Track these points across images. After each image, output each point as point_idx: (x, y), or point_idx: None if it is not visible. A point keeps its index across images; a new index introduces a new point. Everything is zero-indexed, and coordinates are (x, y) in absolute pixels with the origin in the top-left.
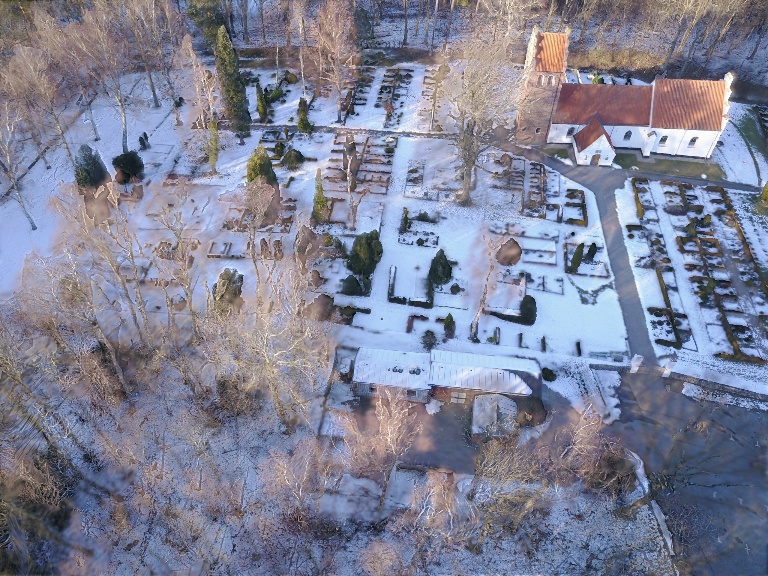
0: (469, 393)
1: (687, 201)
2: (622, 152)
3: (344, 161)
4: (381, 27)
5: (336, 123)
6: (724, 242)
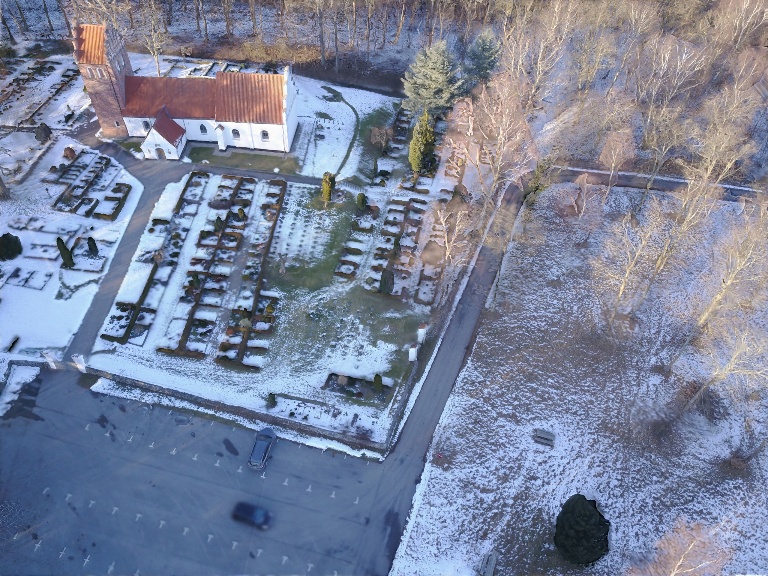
0: None
1: (237, 195)
2: (203, 146)
3: None
4: (83, 19)
5: None
6: (251, 236)
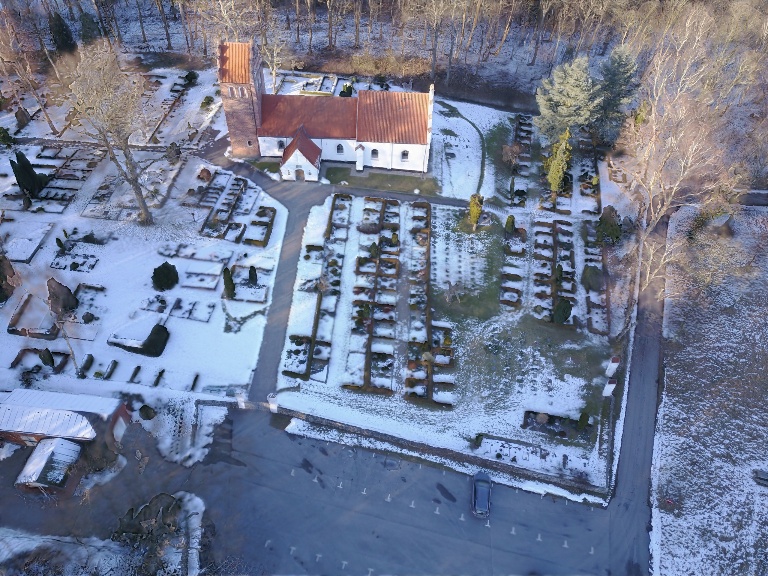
0: (36, 437)
1: (385, 218)
2: (338, 166)
3: (16, 178)
4: (169, 29)
5: (51, 135)
6: (408, 262)
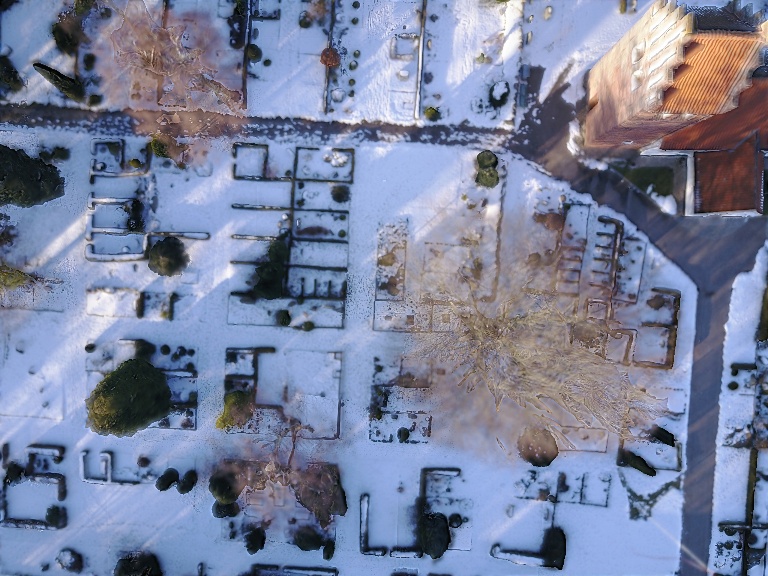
0: None
1: None
2: None
3: None
4: None
5: None
6: None
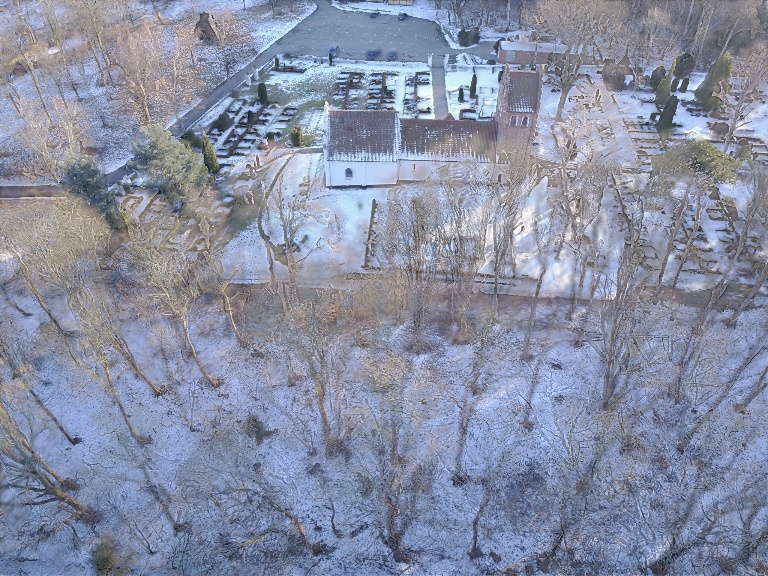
0: None
1: None
2: None
3: None
4: None
5: None
6: None
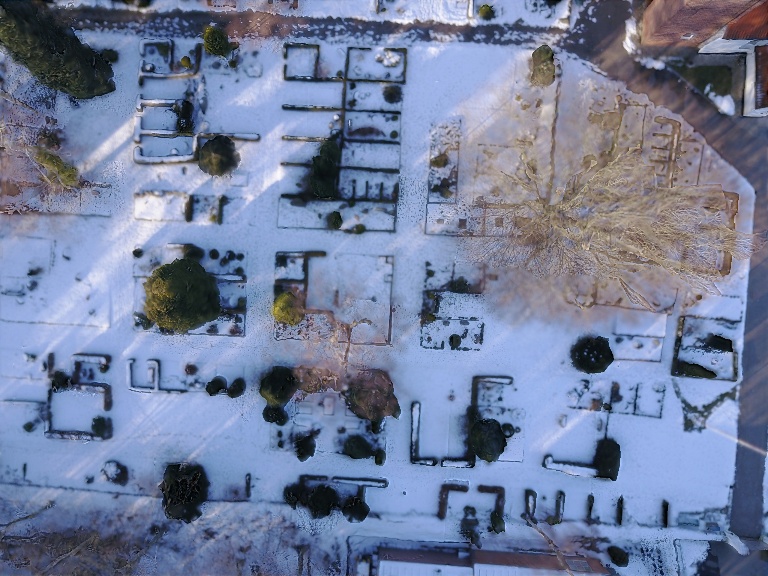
0: None
1: None
2: None
3: (314, 190)
4: None
5: (279, 1)
6: None
